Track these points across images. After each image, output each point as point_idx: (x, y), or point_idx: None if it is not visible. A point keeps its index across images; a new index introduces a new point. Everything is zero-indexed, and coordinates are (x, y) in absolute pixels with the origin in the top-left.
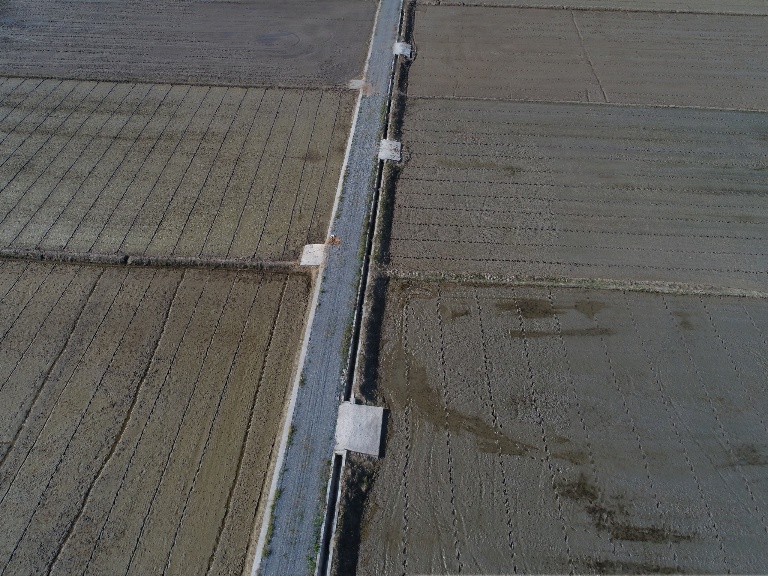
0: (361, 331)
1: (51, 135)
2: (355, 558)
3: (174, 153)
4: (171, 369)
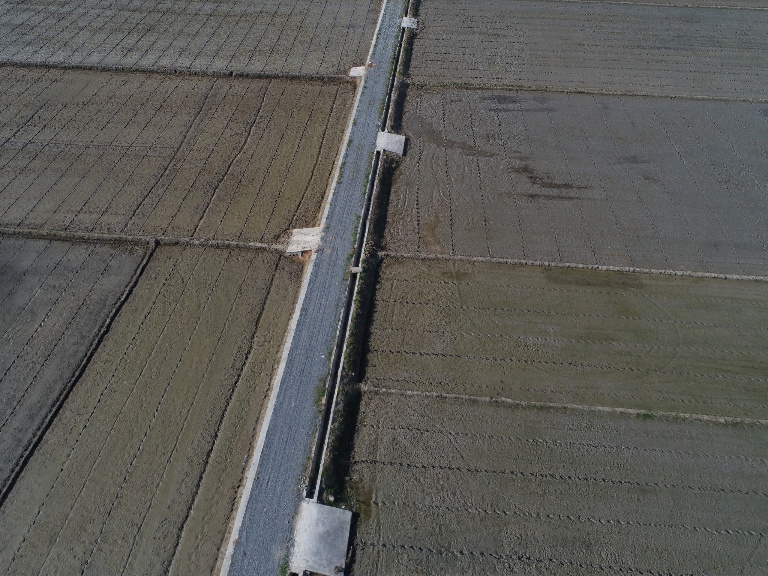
0: (391, 104)
1: (164, 13)
2: (389, 190)
3: (254, 23)
4: (270, 121)
